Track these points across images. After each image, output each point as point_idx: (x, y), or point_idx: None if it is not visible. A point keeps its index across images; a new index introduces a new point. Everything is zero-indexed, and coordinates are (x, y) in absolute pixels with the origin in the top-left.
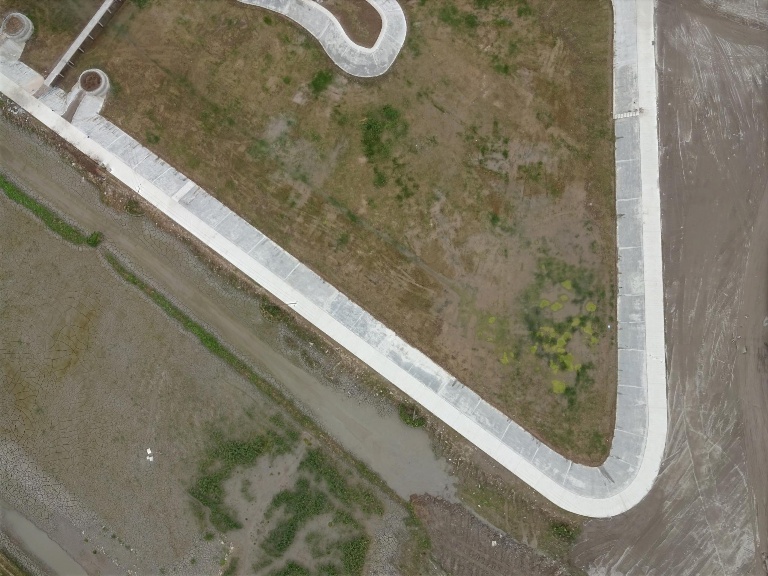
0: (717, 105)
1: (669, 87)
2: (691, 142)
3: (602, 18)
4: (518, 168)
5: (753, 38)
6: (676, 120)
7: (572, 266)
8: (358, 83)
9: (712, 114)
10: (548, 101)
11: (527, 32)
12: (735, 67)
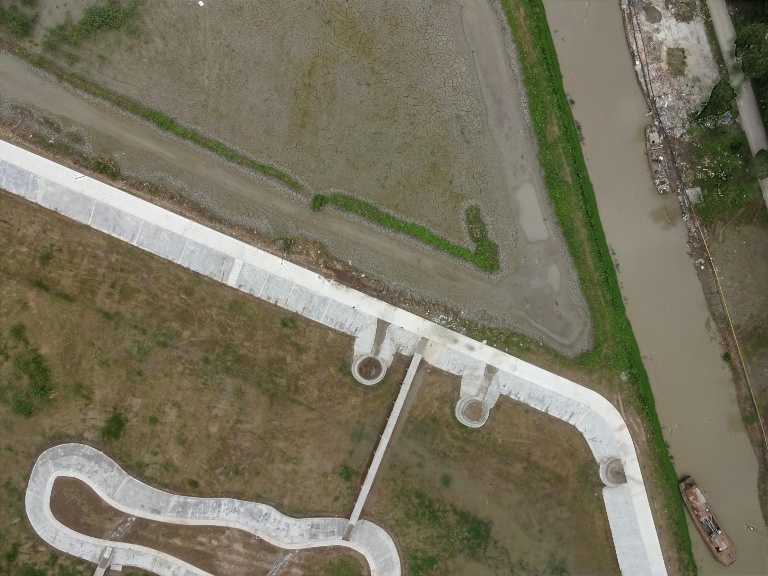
0: None
1: None
2: None
3: None
4: None
5: None
6: None
7: None
8: (70, 436)
9: None
10: None
11: None
12: None
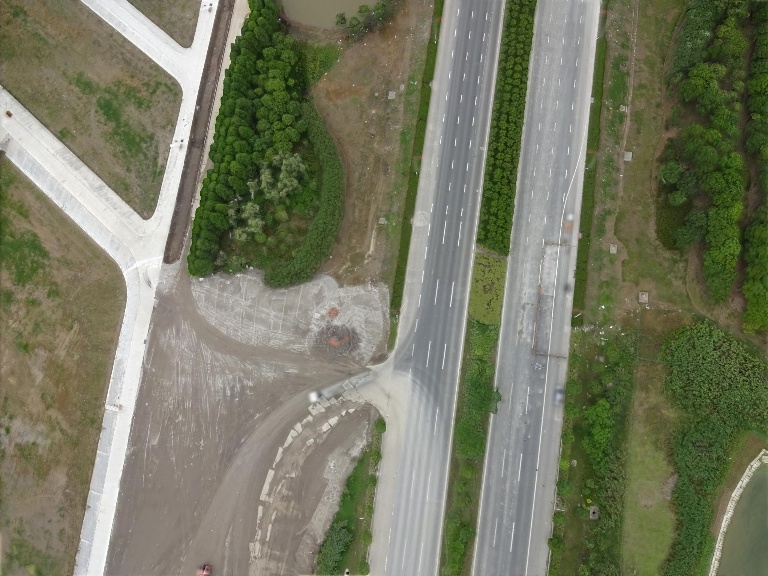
0: (187, 411)
1: (149, 387)
2: (157, 445)
3: (116, 308)
4: (15, 445)
5: (232, 348)
6: (148, 421)
7: (39, 550)
8: None
9: (181, 420)
10: (54, 383)
11: (52, 313)
12: (211, 375)
